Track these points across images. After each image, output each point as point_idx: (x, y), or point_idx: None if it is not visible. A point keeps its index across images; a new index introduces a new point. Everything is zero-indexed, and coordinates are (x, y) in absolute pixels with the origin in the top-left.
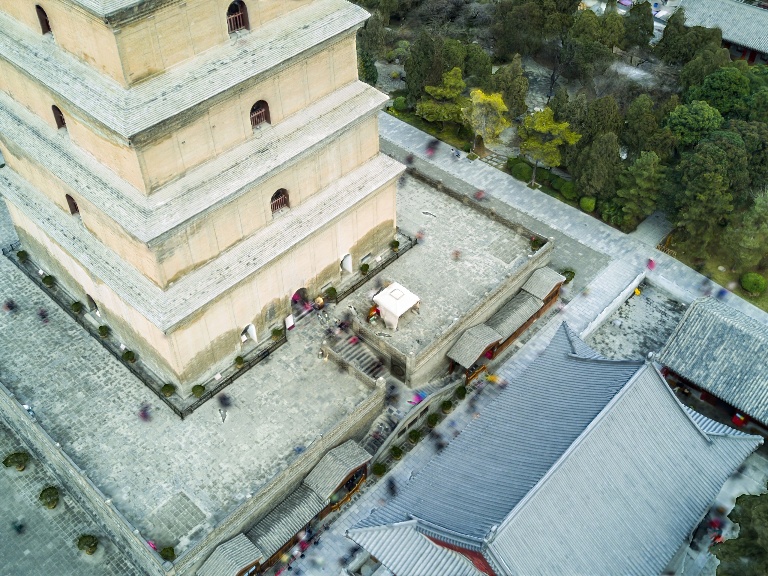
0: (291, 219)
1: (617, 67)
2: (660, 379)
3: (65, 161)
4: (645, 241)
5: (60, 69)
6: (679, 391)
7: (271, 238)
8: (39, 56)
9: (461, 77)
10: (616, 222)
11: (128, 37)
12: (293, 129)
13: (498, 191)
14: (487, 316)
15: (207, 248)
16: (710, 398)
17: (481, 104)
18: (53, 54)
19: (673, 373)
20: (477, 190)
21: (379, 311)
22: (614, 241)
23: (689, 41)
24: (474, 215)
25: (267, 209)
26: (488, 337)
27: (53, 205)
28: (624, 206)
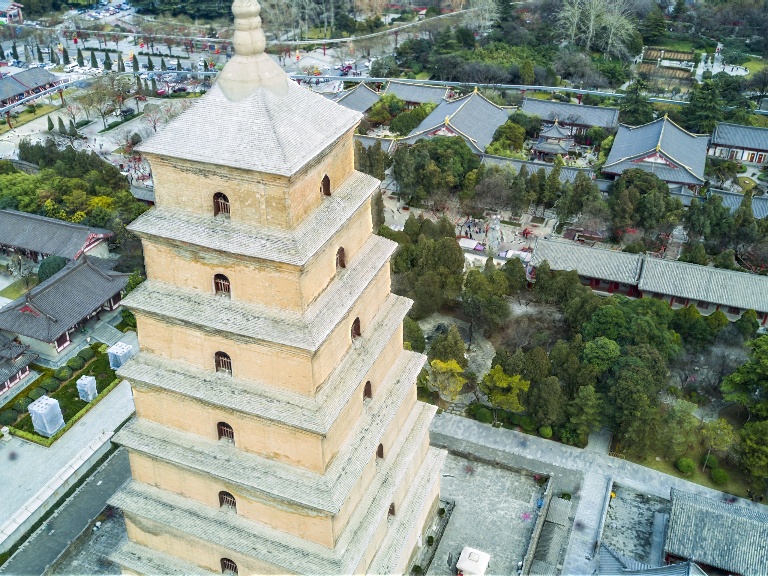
0: (397, 524)
1: (513, 312)
2: (702, 573)
3: (236, 534)
4: (598, 451)
5: (247, 467)
6: None
7: (391, 545)
8: (219, 458)
9: (411, 349)
10: (574, 442)
11: (326, 438)
12: (395, 456)
13: (474, 437)
14: (533, 552)
15: (361, 572)
16: (706, 568)
17: (444, 371)
18: (234, 455)
19: (674, 556)
20: (458, 440)
21: (463, 575)
22: (578, 457)
23: (560, 284)
24: (482, 468)
25: (386, 523)
26: (547, 570)
27: (196, 568)
28: (578, 429)
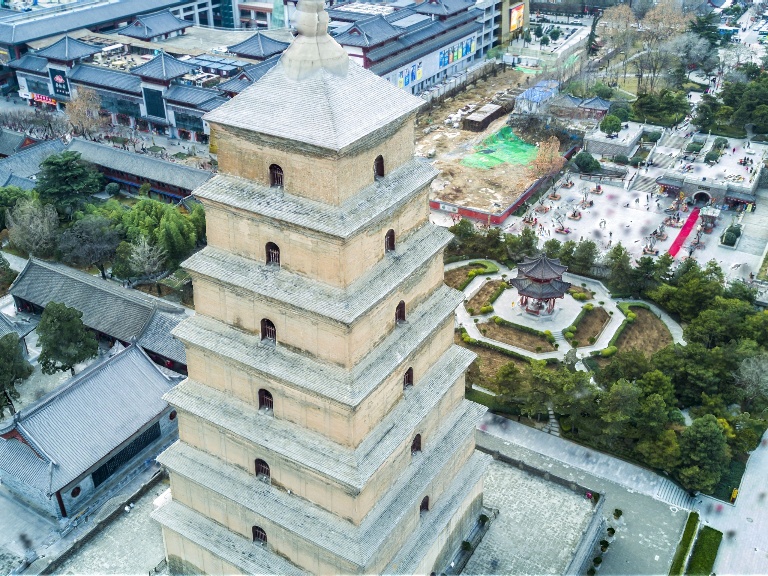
0: None
1: None
2: None
3: None
4: None
5: None
6: None
7: None
8: None
9: None
10: None
11: None
12: None
13: None
14: None
15: None
16: None
17: None
18: None
19: None
20: None
21: None
22: None
23: None
24: None
25: None
26: (106, 511)
27: None
28: None
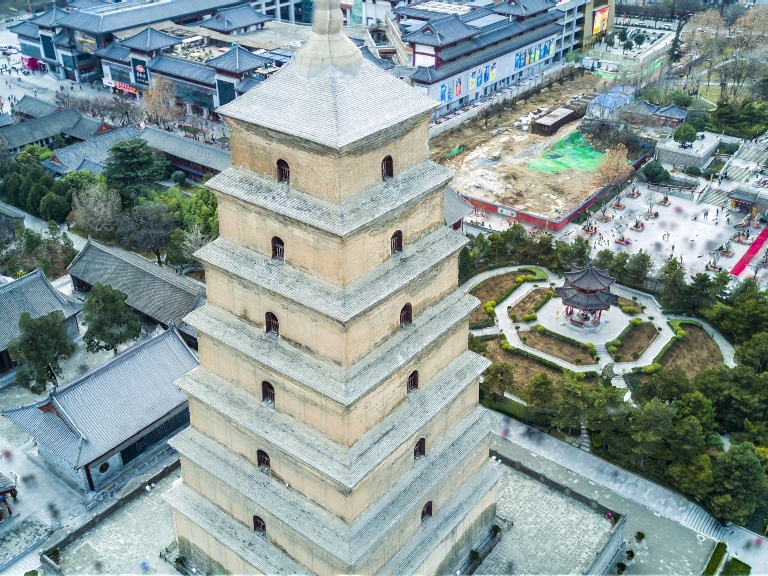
0: None
1: None
2: None
3: None
4: None
5: None
6: (0, 507)
7: None
8: None
9: None
10: None
11: None
12: None
13: None
14: None
15: None
16: None
17: None
18: None
19: None
20: None
21: None
22: None
23: None
24: None
25: None
26: (128, 488)
27: None
28: None
